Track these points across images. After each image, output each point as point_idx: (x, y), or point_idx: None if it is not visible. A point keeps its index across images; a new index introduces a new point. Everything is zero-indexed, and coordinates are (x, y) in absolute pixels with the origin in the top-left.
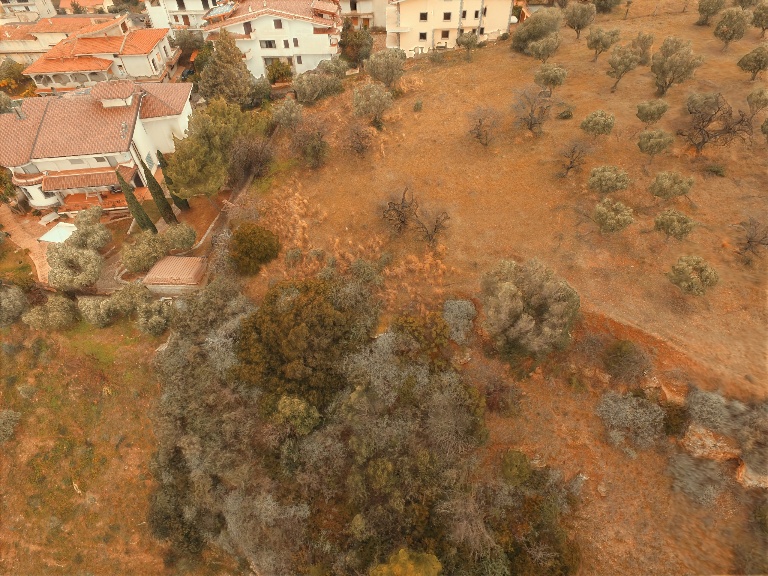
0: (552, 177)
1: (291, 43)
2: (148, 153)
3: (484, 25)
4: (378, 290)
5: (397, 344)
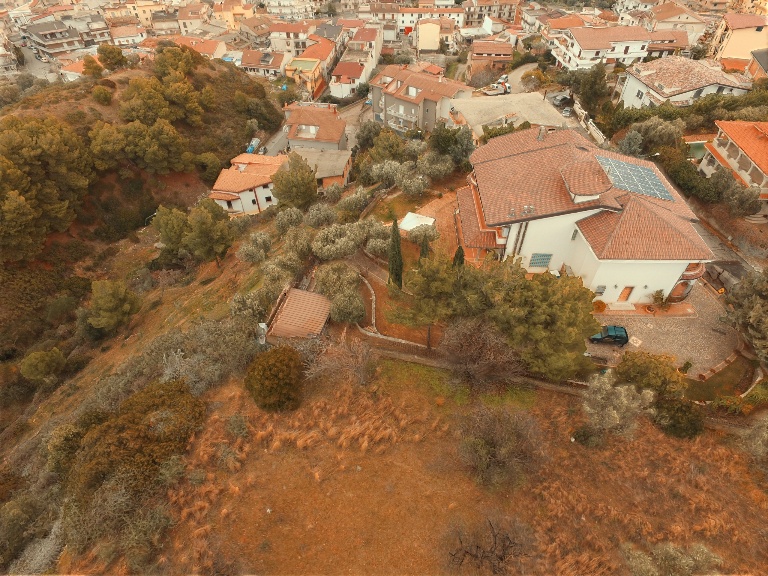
0: None
1: None
2: (550, 254)
3: None
4: None
5: (20, 574)
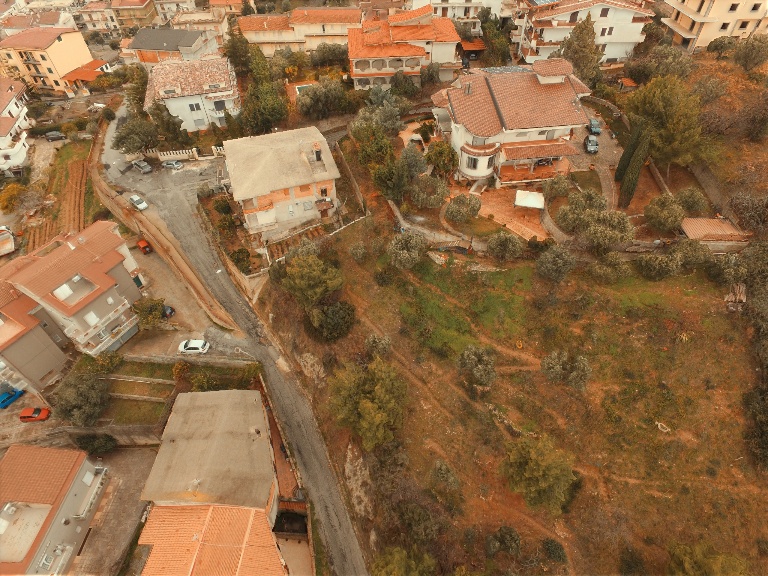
0: None
1: (607, 31)
2: None
3: None
4: None
5: None
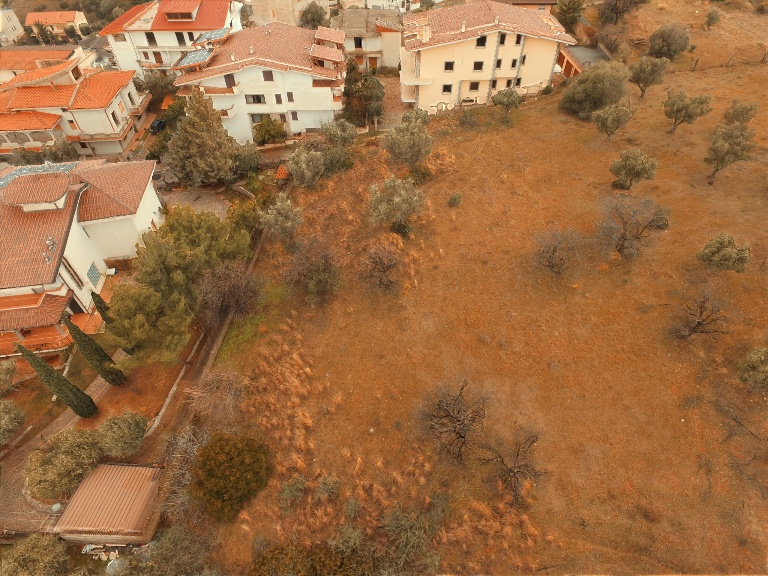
0: (664, 336)
1: (284, 98)
2: (92, 263)
3: (521, 75)
4: (430, 572)
5: None
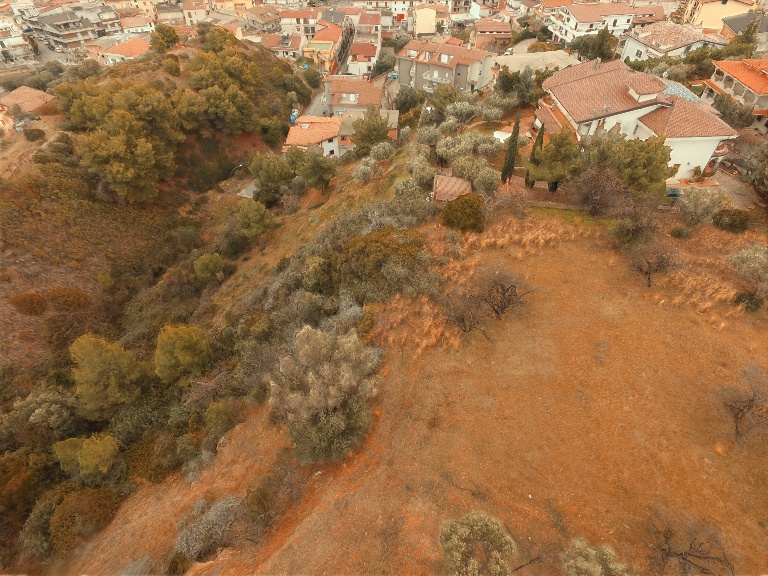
0: None
1: None
2: None
3: None
4: None
5: None
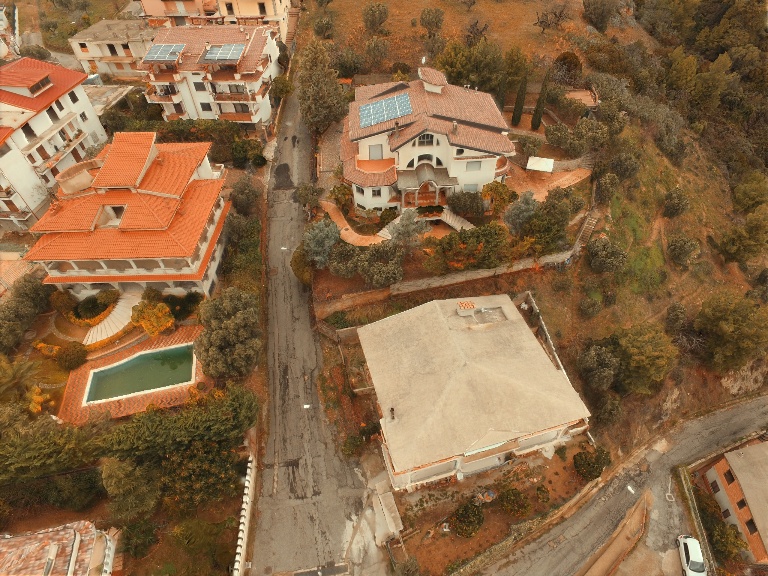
0: None
1: None
2: None
3: None
4: None
5: None
